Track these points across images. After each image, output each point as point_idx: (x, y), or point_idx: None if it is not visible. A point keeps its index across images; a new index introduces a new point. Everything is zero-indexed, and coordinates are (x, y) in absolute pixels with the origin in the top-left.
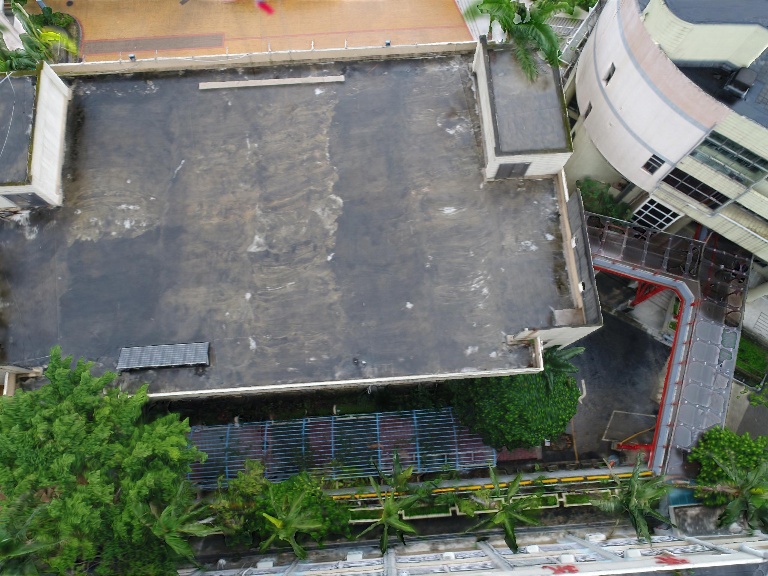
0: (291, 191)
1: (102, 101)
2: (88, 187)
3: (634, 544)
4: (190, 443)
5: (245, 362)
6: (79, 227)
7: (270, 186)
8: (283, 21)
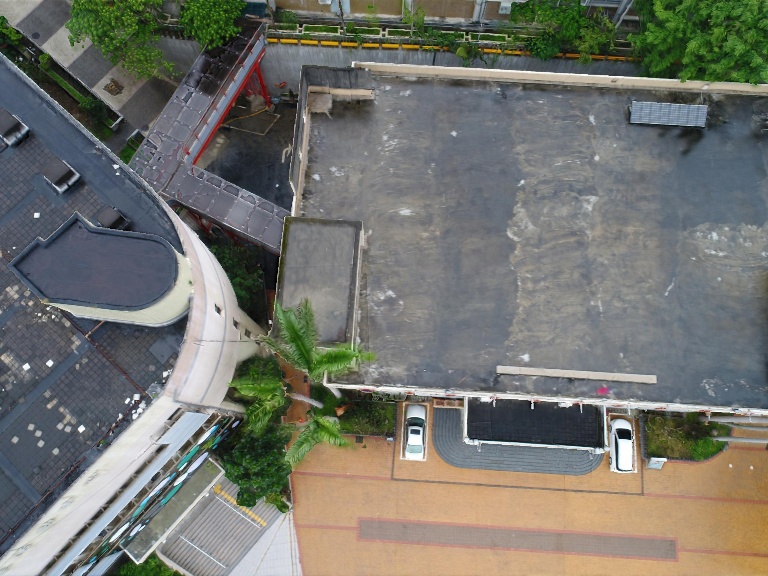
0: (557, 249)
1: (761, 376)
2: (759, 278)
3: None
4: (637, 76)
5: (598, 106)
6: (761, 239)
7: (578, 257)
8: None
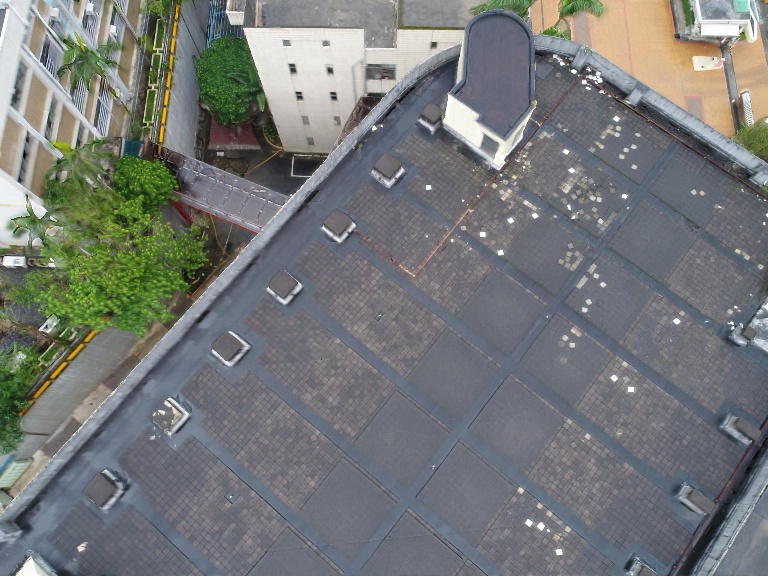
0: None
1: None
2: None
3: (101, 98)
4: None
5: None
6: None
7: None
8: (641, 4)
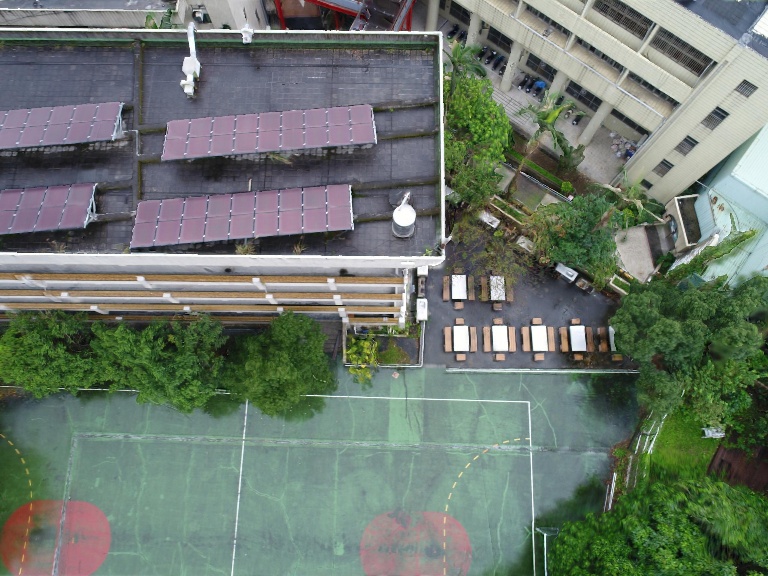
0: None
1: None
2: None
3: None
4: None
5: None
6: None
7: None
8: None
